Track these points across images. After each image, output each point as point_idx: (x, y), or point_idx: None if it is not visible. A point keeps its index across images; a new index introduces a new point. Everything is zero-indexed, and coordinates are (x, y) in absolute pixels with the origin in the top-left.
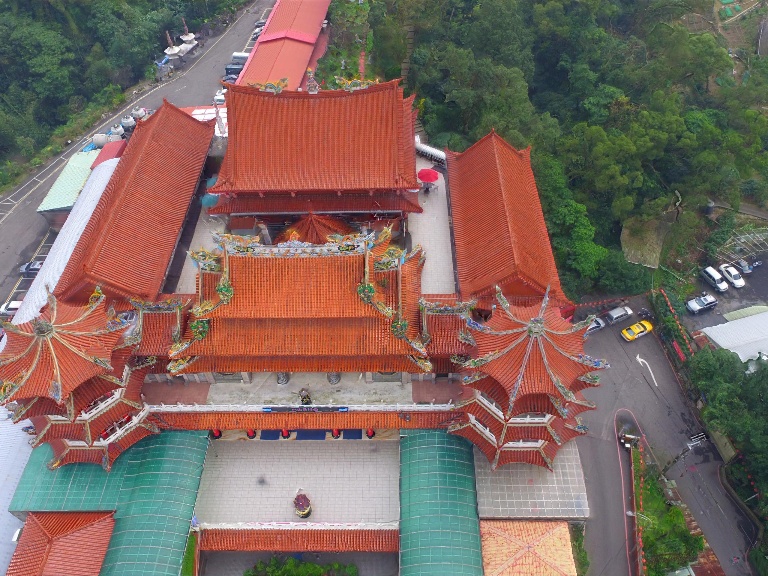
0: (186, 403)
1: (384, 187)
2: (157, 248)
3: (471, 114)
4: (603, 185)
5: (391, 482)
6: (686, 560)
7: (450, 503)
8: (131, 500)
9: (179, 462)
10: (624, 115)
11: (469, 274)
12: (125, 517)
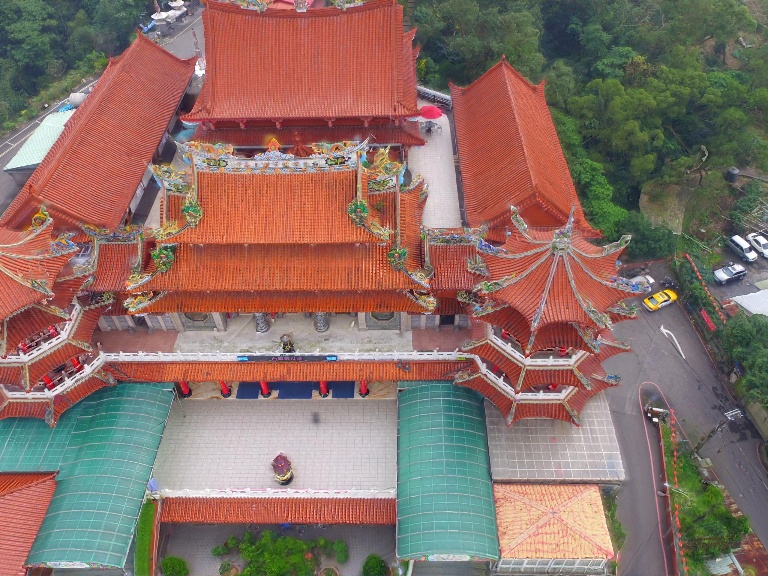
0: (148, 351)
1: (381, 114)
2: (121, 179)
3: (476, 72)
4: (621, 142)
5: (387, 445)
6: (728, 546)
7: (457, 462)
8: (77, 459)
9: (137, 417)
10: (640, 76)
11: (478, 205)
12: (68, 478)
